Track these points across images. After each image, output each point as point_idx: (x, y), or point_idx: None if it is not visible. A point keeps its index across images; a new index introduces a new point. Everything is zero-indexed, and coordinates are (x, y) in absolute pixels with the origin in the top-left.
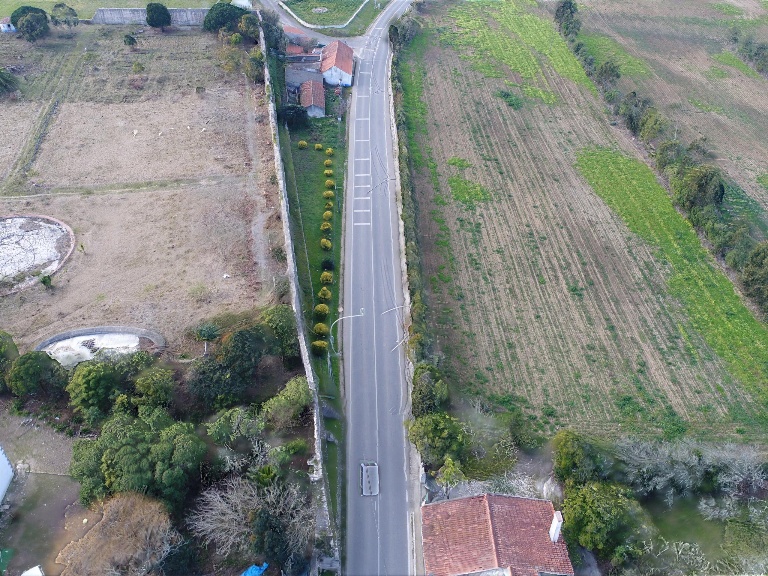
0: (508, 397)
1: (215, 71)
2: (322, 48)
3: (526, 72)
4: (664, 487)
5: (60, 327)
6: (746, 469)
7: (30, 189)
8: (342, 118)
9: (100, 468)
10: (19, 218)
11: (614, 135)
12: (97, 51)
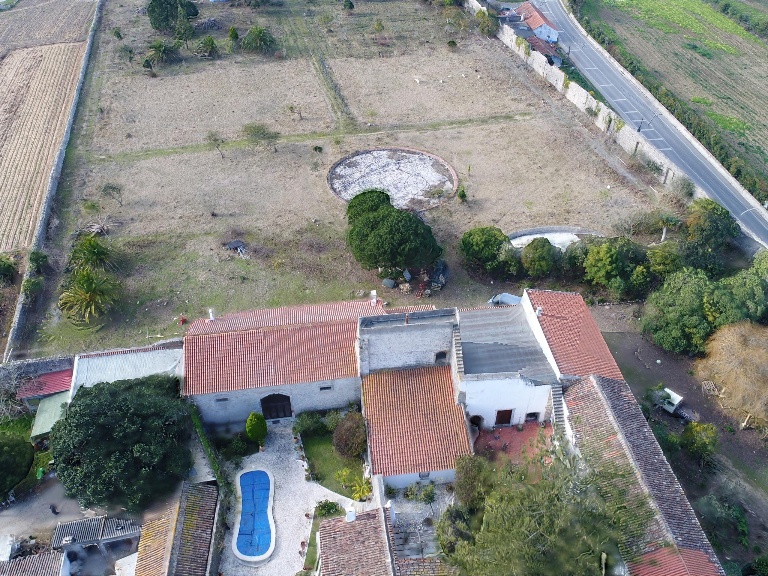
0: None
1: (446, 29)
2: (512, 10)
3: (695, 28)
4: None
5: (502, 230)
6: None
7: (367, 128)
8: (574, 68)
9: (703, 307)
10: (381, 151)
11: None
12: (315, 16)
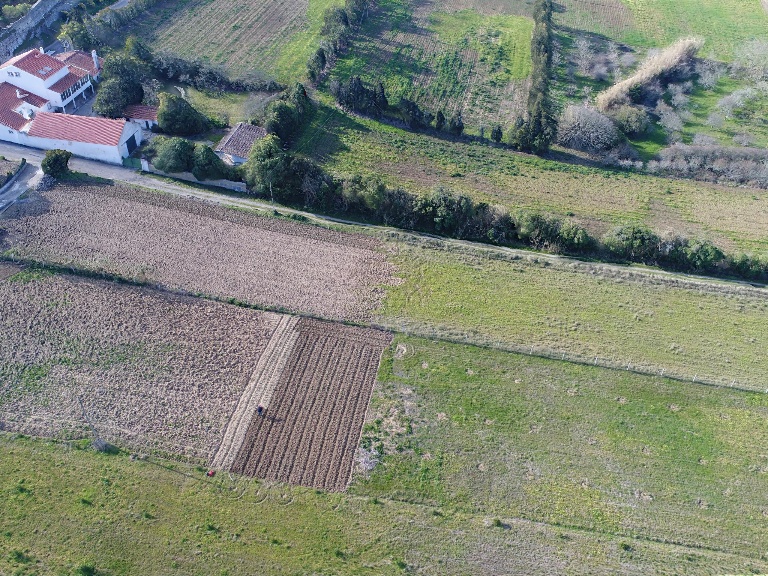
0: (144, 46)
1: None
2: None
3: None
4: (168, 67)
5: None
6: (232, 82)
7: None
8: None
9: None
10: None
11: None
12: None
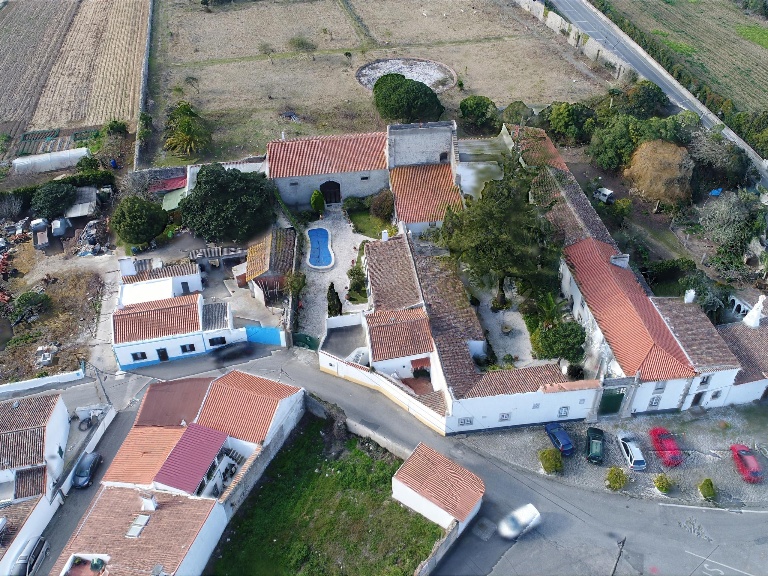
0: None
1: None
2: None
3: None
4: None
5: None
6: None
7: (385, 45)
8: None
9: (629, 133)
10: (397, 59)
11: (752, 20)
12: None
